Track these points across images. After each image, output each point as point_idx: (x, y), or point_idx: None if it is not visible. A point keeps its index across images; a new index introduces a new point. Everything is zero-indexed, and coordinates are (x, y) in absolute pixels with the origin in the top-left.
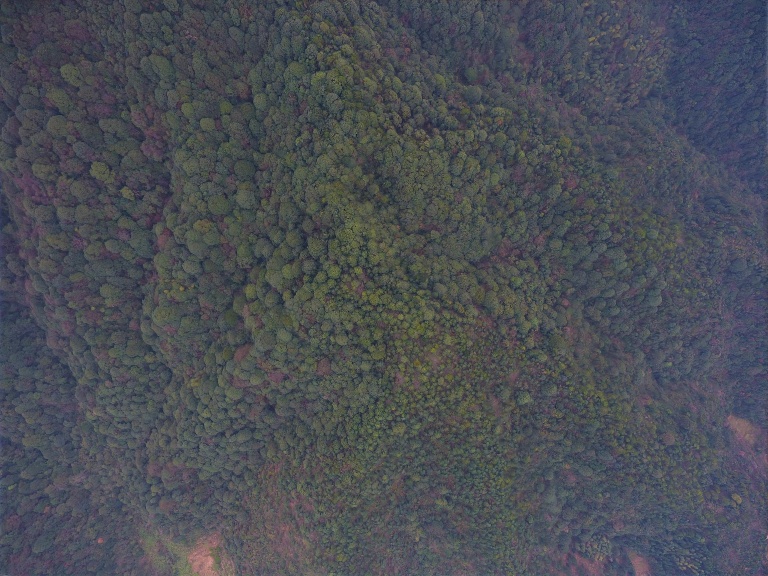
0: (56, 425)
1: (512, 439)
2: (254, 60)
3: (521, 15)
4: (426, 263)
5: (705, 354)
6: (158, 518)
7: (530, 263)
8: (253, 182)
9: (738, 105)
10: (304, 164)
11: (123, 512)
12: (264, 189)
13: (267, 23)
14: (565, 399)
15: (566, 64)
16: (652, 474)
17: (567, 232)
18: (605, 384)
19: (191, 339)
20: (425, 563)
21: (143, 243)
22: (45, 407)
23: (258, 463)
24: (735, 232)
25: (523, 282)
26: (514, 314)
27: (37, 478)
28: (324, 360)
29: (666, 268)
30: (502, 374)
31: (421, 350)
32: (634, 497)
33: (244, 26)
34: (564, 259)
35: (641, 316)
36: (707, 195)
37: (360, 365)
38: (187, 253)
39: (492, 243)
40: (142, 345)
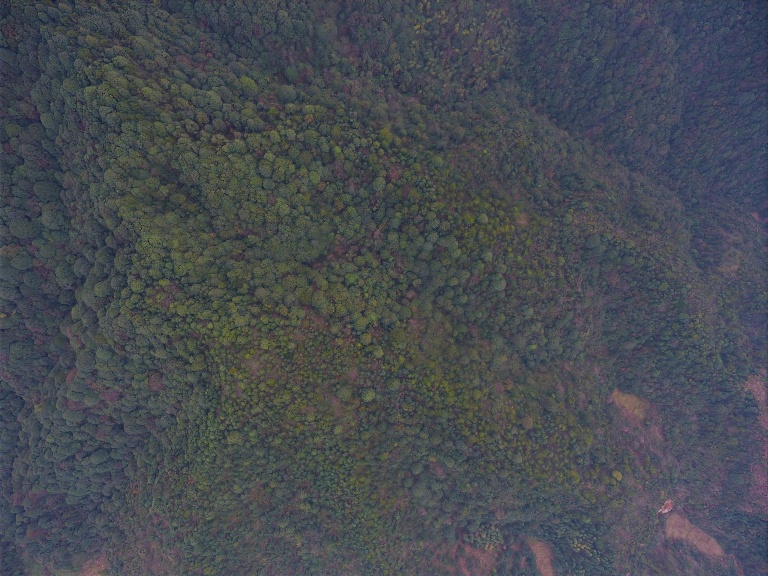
0: None
1: (360, 437)
2: (34, 80)
3: (340, 9)
4: (246, 268)
5: (572, 333)
6: (31, 547)
7: (367, 258)
8: (61, 202)
9: (589, 80)
10: (95, 180)
11: (4, 543)
12: (71, 208)
13: (36, 41)
14: (411, 392)
15: (393, 54)
16: (512, 460)
17: (402, 224)
18: (452, 373)
19: (29, 365)
20: (311, 568)
21: None
22: None
23: (124, 483)
24: (585, 208)
25: (358, 278)
26: (348, 311)
27: None
28: (155, 375)
29: (505, 251)
30: (336, 373)
31: (236, 357)
32: (504, 484)
33: (13, 47)
34: (404, 251)
35: (493, 301)
36: (562, 173)
37: (187, 377)
38: None
39: (325, 242)
40: None
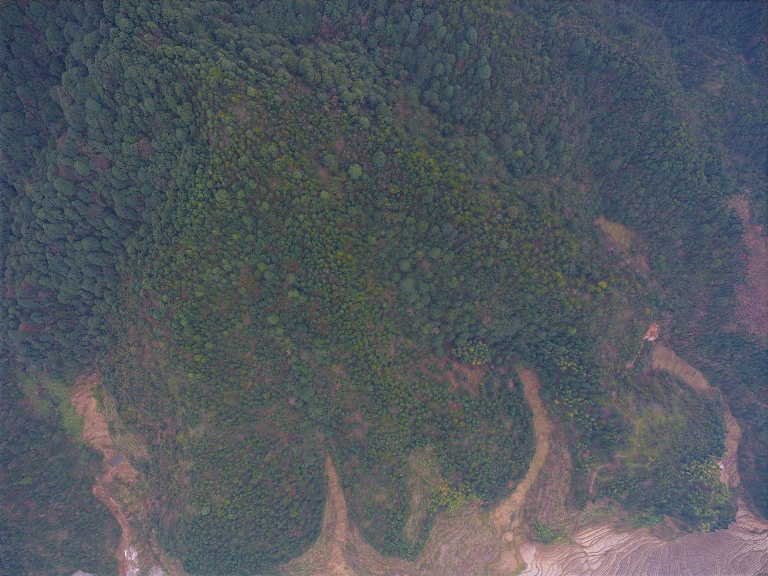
0: None
1: (347, 212)
2: None
3: None
4: (233, 30)
5: (558, 143)
6: (24, 347)
7: (354, 42)
8: None
9: None
10: None
11: None
12: None
13: None
14: (397, 168)
15: None
16: (498, 245)
17: (388, 8)
18: (437, 153)
19: (21, 143)
20: (301, 378)
21: None
22: None
23: (115, 280)
24: (570, 12)
25: (345, 57)
26: (335, 84)
27: None
28: (144, 139)
29: (489, 35)
30: (323, 138)
31: (223, 100)
32: (490, 279)
33: None
34: (390, 38)
35: (479, 96)
36: None
37: (175, 134)
38: None
39: (312, 22)
40: None
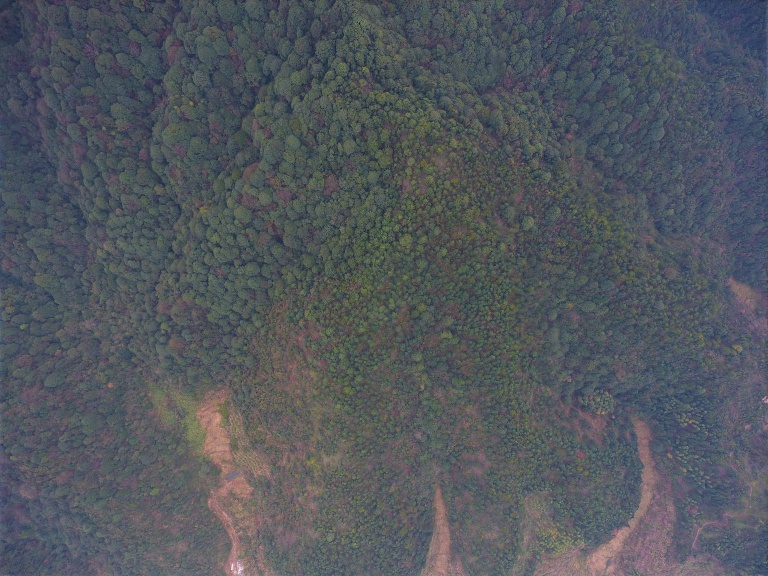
0: (67, 268)
1: (516, 263)
2: None
3: None
4: (432, 77)
5: (707, 205)
6: (167, 361)
7: (534, 94)
8: None
9: None
10: None
11: (132, 364)
12: None
13: None
14: (569, 224)
15: None
16: (654, 306)
17: (571, 63)
18: (608, 211)
19: (200, 166)
20: (430, 413)
21: (153, 58)
22: (56, 247)
23: (266, 304)
24: (737, 77)
25: (527, 109)
26: (519, 137)
27: (48, 321)
28: (332, 176)
29: (669, 98)
30: (507, 190)
31: (428, 150)
32: (636, 336)
33: None
34: (568, 92)
35: (644, 155)
36: (709, 50)
37: (367, 176)
38: (197, 61)
39: (497, 72)
40: (152, 176)
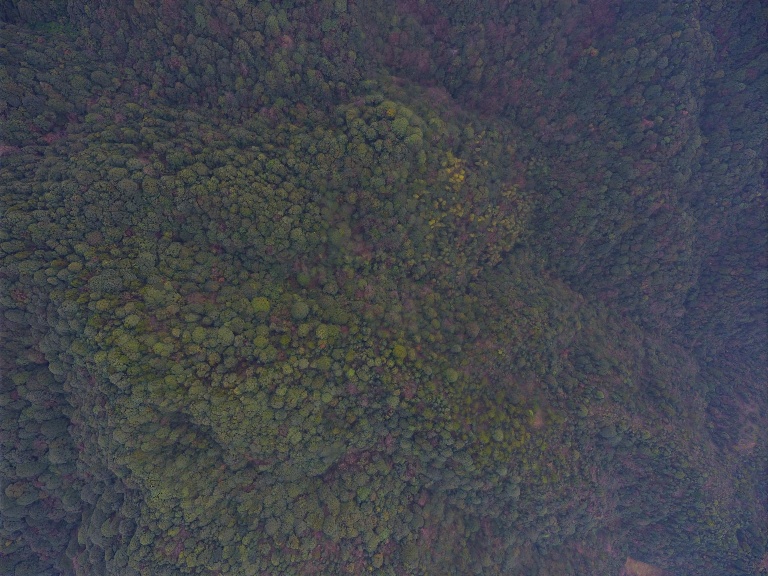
0: None
1: None
2: (42, 331)
3: (354, 208)
4: (256, 499)
5: (585, 518)
6: None
7: (379, 468)
8: (68, 434)
9: (605, 252)
10: (104, 432)
11: None
12: (78, 443)
13: (45, 302)
14: None
15: (407, 251)
16: None
17: (415, 433)
18: None
19: None
20: None
21: None
22: None
23: None
24: (601, 399)
25: (370, 492)
26: (360, 531)
27: None
28: None
29: (520, 462)
30: None
31: None
32: None
33: (21, 307)
34: (416, 457)
35: (506, 500)
36: (577, 352)
37: None
38: (3, 516)
39: (337, 453)
40: None
